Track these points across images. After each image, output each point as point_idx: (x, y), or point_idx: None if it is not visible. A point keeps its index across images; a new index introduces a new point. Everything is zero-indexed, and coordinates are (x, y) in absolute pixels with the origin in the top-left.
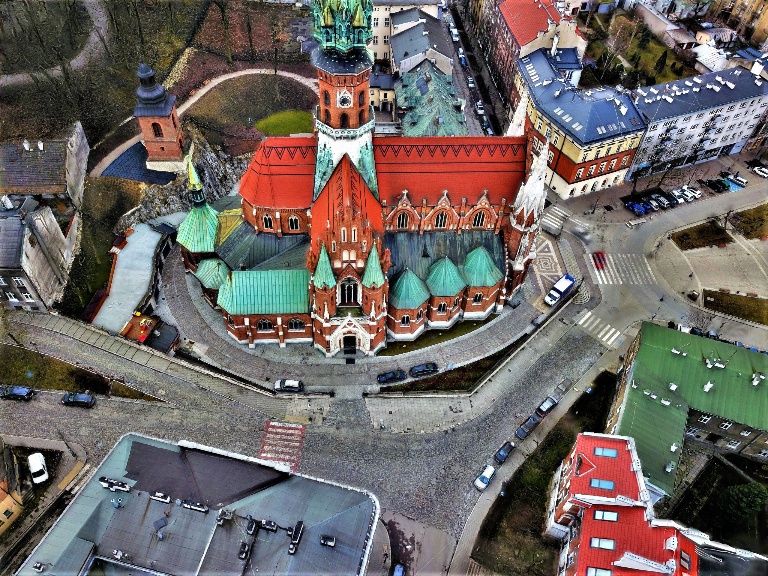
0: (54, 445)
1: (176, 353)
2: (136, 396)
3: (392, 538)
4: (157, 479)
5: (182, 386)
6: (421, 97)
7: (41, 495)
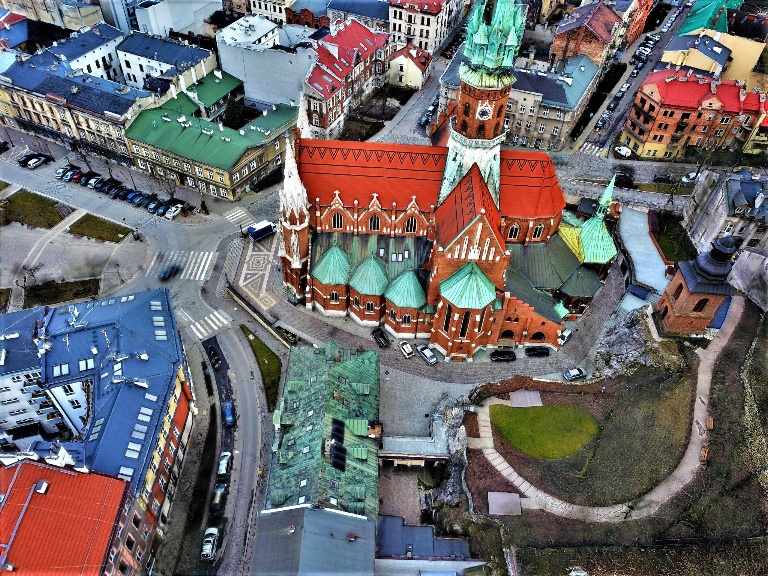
0: (622, 161)
1: (577, 211)
2: (589, 180)
3: (425, 133)
4: (547, 84)
5: (562, 186)
6: (346, 419)
7: (614, 146)
